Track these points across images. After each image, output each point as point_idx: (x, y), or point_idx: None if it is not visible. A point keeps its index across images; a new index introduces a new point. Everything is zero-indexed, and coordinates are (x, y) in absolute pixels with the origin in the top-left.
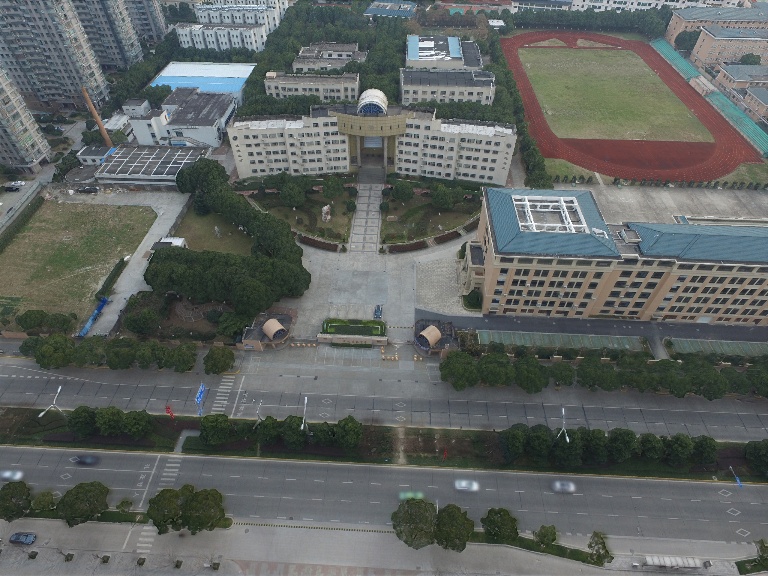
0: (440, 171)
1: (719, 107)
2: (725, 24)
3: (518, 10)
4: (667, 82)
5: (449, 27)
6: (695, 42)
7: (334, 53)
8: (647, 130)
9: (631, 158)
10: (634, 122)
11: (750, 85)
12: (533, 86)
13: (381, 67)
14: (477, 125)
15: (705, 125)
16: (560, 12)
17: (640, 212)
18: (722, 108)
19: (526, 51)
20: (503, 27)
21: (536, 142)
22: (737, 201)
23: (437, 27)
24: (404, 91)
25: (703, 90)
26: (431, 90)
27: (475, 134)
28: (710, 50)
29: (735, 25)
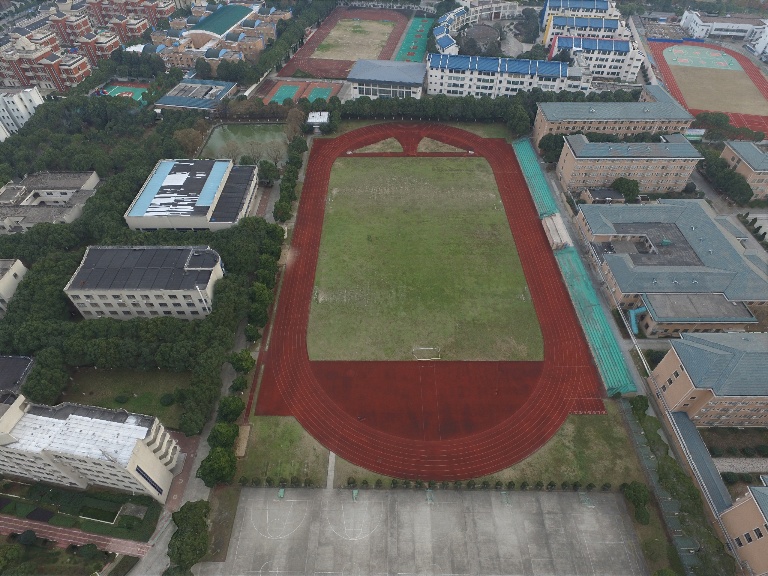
0: (58, 479)
1: (567, 278)
2: (601, 124)
3: (359, 91)
4: (512, 221)
5: (263, 121)
6: (560, 152)
7: (53, 191)
8: (449, 335)
9: (402, 409)
10: (437, 316)
11: (614, 238)
12: (323, 237)
13: (89, 227)
14: (97, 416)
15: (539, 318)
16: (400, 101)
17: (363, 573)
18: (570, 280)
19: (344, 164)
20: (322, 126)
21: (238, 404)
22: (537, 527)
23: (247, 121)
24: (71, 296)
25: (553, 242)
26: (111, 294)
27: (67, 454)
28: (572, 171)
29: (614, 125)
